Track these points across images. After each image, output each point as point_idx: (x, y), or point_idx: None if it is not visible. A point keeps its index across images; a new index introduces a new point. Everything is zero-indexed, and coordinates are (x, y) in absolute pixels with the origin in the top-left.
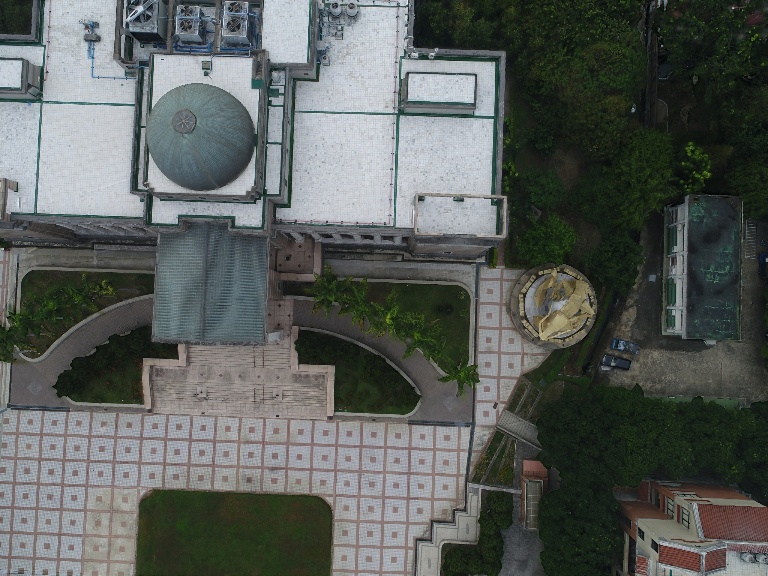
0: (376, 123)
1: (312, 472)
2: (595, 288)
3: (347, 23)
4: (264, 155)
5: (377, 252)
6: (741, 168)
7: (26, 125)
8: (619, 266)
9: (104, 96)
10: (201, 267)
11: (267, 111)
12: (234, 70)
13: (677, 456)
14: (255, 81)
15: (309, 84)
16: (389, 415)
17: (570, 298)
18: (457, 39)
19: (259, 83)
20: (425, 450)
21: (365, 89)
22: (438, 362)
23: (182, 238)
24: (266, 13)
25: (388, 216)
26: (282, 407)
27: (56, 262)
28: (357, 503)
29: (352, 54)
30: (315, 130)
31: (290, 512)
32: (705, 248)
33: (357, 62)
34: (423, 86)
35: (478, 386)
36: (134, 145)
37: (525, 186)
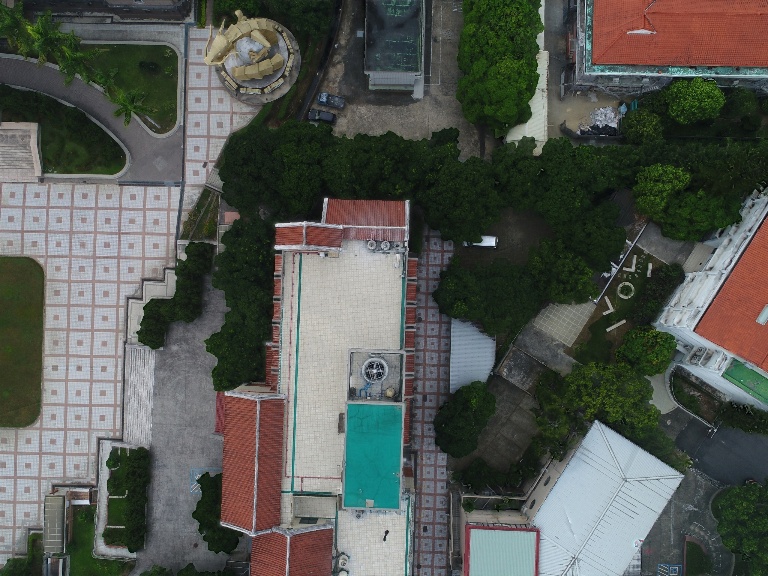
0: None
1: (24, 234)
2: (299, 42)
3: None
4: None
5: (86, 15)
6: None
7: None
8: (303, 4)
9: None
10: None
11: None
12: None
13: (339, 175)
14: None
15: None
16: (98, 175)
17: (236, 24)
18: None
19: None
20: (135, 210)
21: None
22: (109, 93)
23: None
24: None
25: None
26: None
27: None
28: (68, 263)
29: None
30: None
31: (2, 273)
32: None
33: None
34: None
35: (188, 146)
36: None
37: None
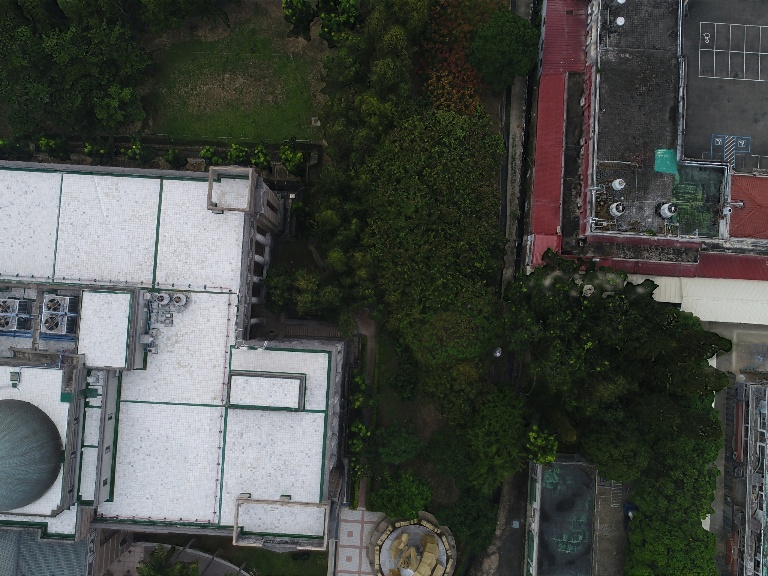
0: (204, 415)
1: None
2: (455, 536)
3: (177, 310)
4: (78, 462)
5: None
6: (595, 437)
7: None
8: (471, 531)
9: None
10: (11, 574)
11: (84, 413)
12: (43, 382)
13: None
14: (64, 394)
15: (136, 372)
16: None
17: None
18: (300, 311)
19: (68, 397)
20: None
21: (193, 379)
22: None
23: None
24: (84, 313)
25: (213, 513)
26: None
27: None
28: None
29: (181, 342)
30: (141, 421)
31: None
32: (558, 516)
33: (186, 351)
34: (246, 389)
35: None
36: None
37: (379, 442)
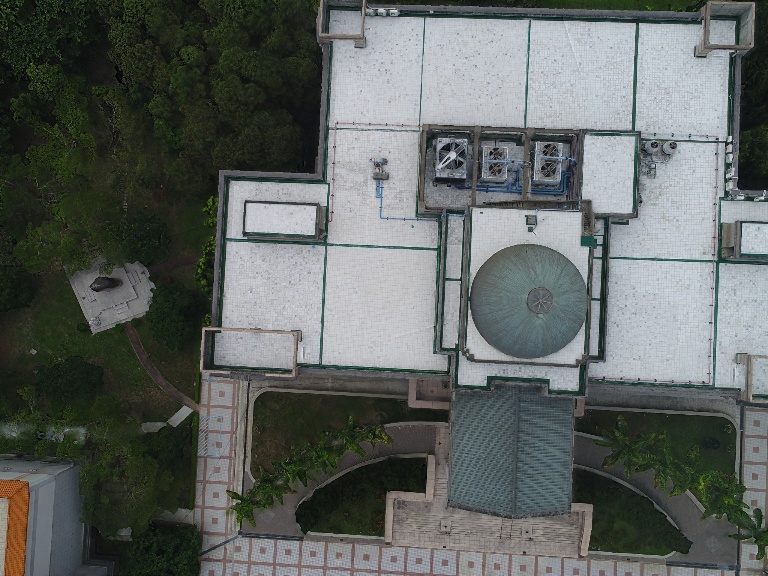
0: (693, 271)
1: None
2: None
3: (660, 160)
4: None
5: None
6: None
7: (310, 269)
8: None
9: (393, 239)
10: (511, 433)
11: None
12: (561, 225)
13: None
14: (585, 238)
15: (618, 227)
16: (646, 555)
17: None
18: (764, 169)
19: (589, 240)
20: None
21: (680, 233)
22: None
23: (485, 398)
24: (586, 157)
25: (707, 374)
26: (529, 543)
27: (289, 383)
28: None
29: (665, 194)
30: (625, 278)
31: None
32: None
33: (671, 203)
34: (758, 237)
35: None
36: (441, 301)
37: None
